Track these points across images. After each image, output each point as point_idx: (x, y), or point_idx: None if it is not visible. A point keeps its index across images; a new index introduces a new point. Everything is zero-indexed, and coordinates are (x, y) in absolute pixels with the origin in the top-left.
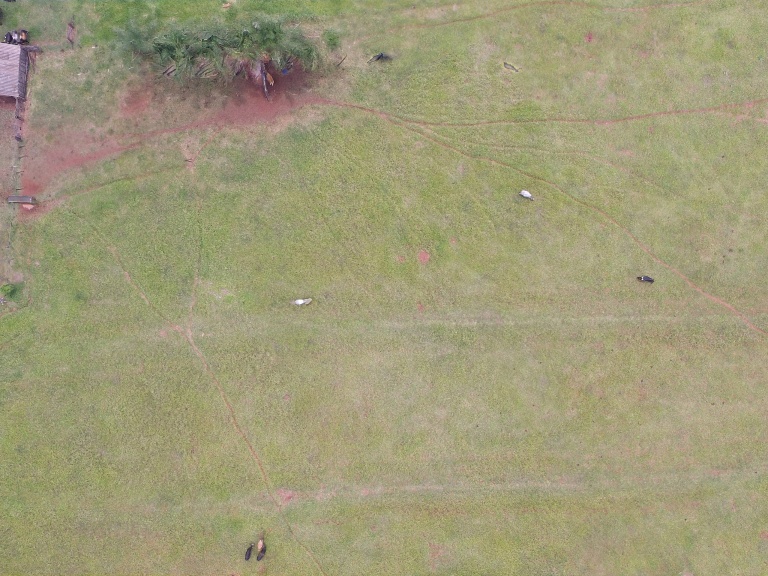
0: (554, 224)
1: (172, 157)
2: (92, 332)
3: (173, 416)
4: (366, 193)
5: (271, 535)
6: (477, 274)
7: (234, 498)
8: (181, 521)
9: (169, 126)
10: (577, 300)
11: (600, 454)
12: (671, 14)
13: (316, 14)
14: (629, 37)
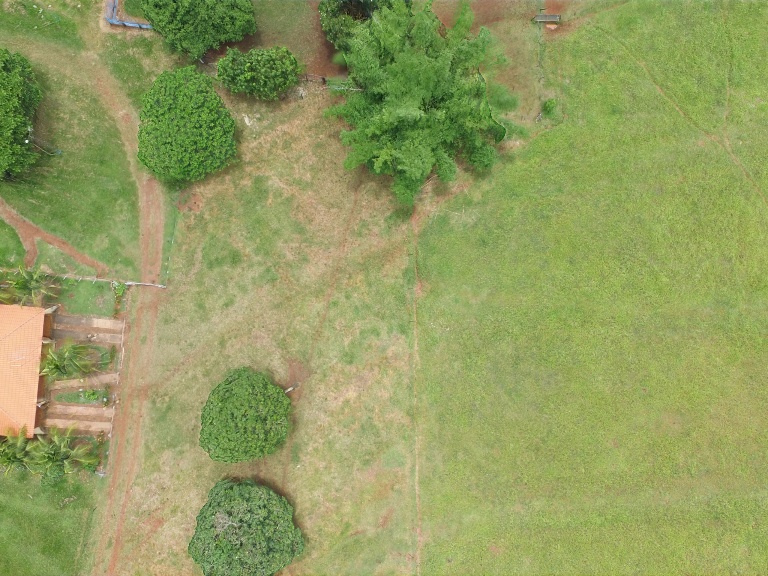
0: None
1: None
2: (630, 145)
3: (720, 222)
4: None
5: None
6: None
7: None
8: (738, 323)
9: None
10: None
11: None
12: None
13: None
14: None
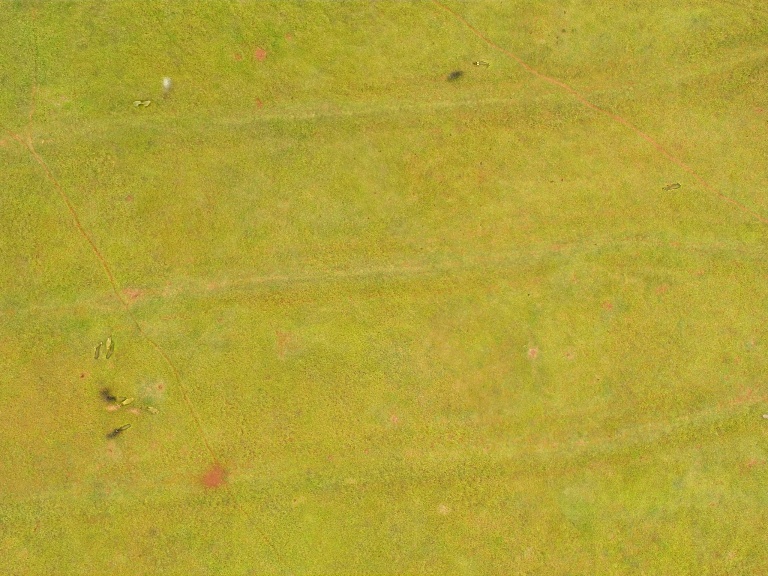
0: (388, 15)
1: None
2: None
3: (16, 222)
4: None
5: (119, 333)
6: (314, 68)
7: (80, 299)
8: (28, 324)
9: None
10: (414, 88)
11: (442, 236)
12: None
13: None
14: None
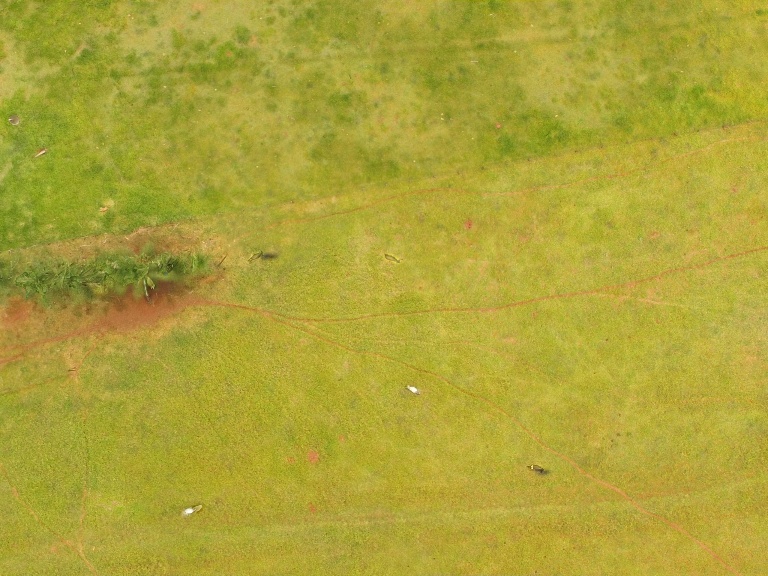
0: (442, 416)
1: (56, 367)
2: None
3: None
4: (252, 395)
5: None
6: (367, 471)
7: None
8: None
9: (51, 336)
10: (468, 492)
11: None
12: (549, 197)
13: (194, 214)
14: (509, 222)
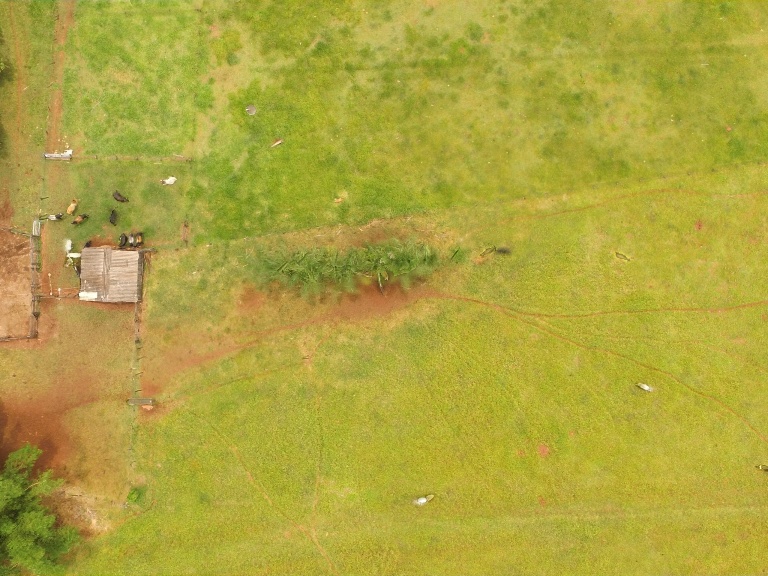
0: (671, 414)
1: (289, 354)
2: (217, 534)
3: None
4: (484, 387)
5: None
6: (596, 466)
7: None
8: None
9: (285, 323)
10: (696, 490)
11: None
12: None
13: (428, 208)
14: (739, 224)
